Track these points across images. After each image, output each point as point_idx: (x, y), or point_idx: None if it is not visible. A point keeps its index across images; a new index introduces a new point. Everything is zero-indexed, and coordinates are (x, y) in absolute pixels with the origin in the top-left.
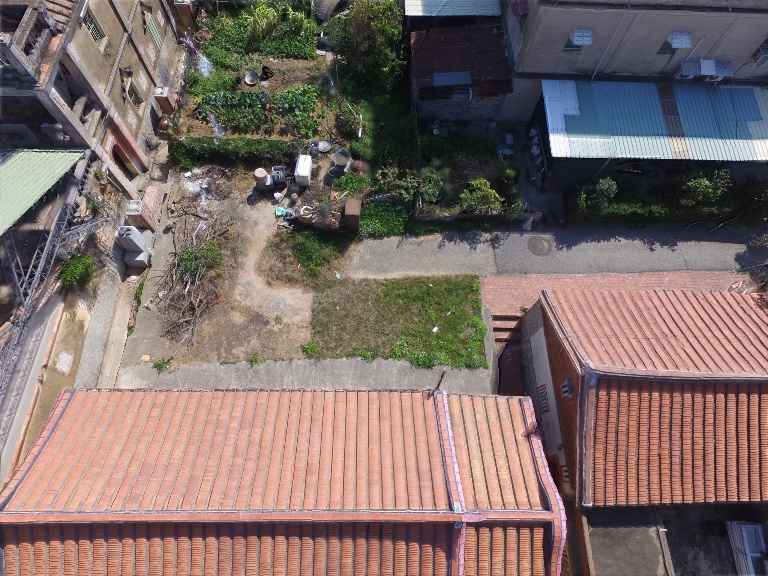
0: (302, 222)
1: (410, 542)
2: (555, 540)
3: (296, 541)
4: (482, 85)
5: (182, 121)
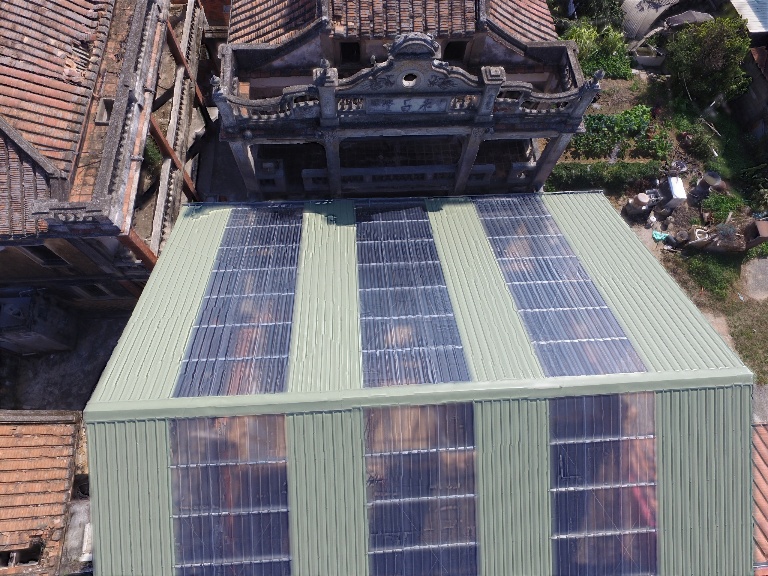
0: (692, 245)
1: None
2: None
3: None
4: None
5: None
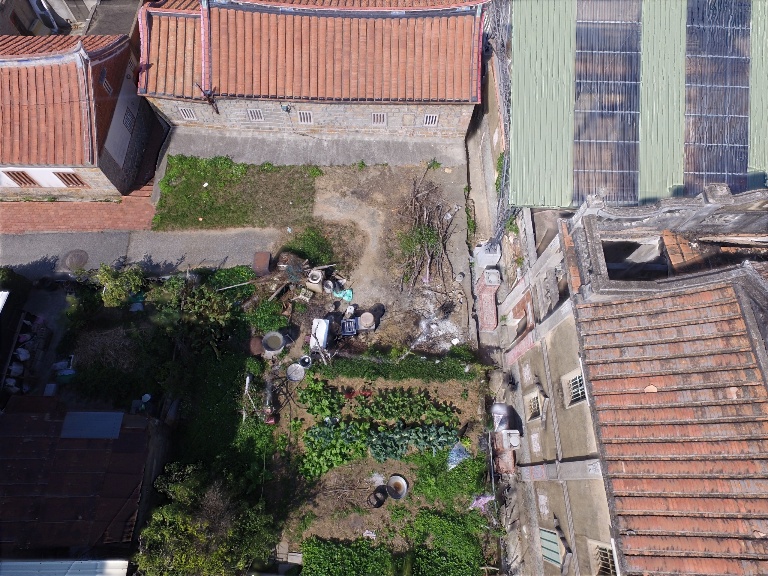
0: None
1: None
2: (151, 2)
3: None
4: (53, 407)
5: (478, 410)
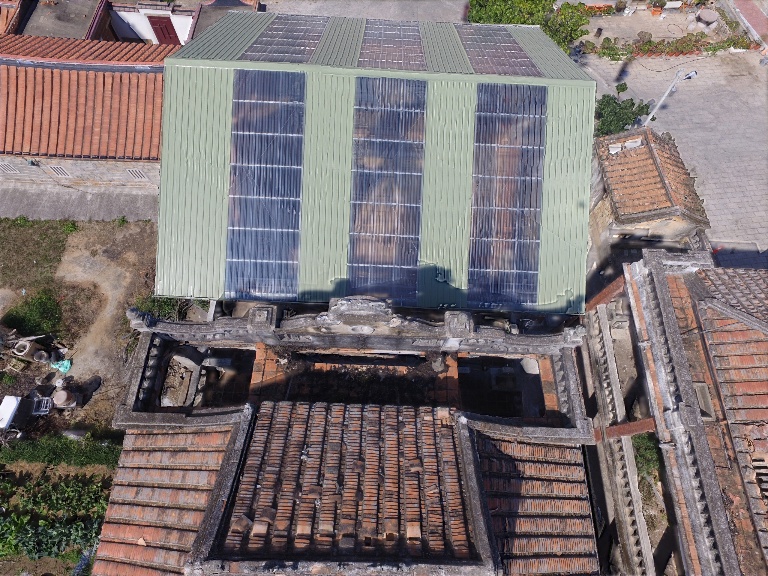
0: None
1: None
2: None
3: None
4: None
5: None
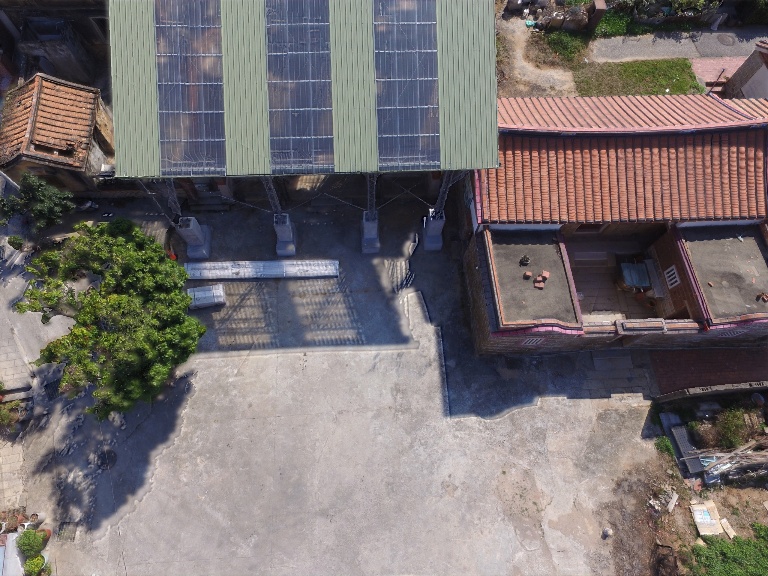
0: (553, 26)
1: (740, 147)
2: None
3: (666, 151)
4: None
5: None
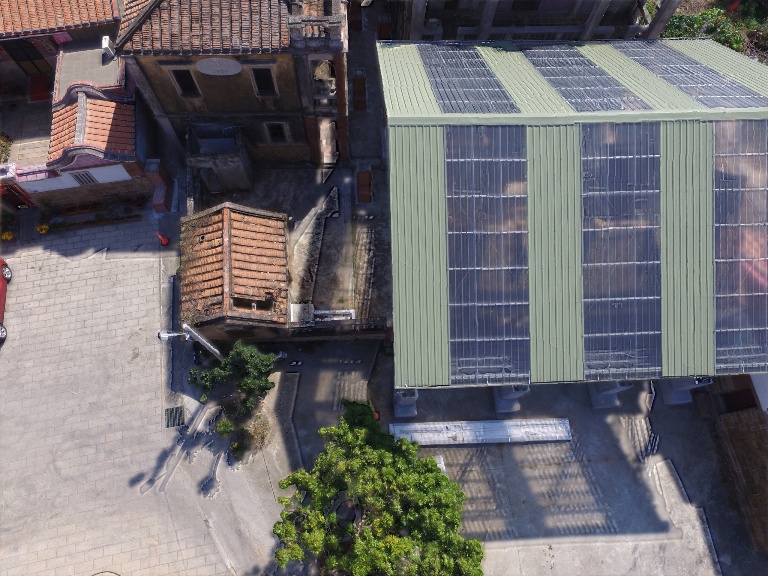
0: None
1: None
2: None
3: None
4: None
5: None
